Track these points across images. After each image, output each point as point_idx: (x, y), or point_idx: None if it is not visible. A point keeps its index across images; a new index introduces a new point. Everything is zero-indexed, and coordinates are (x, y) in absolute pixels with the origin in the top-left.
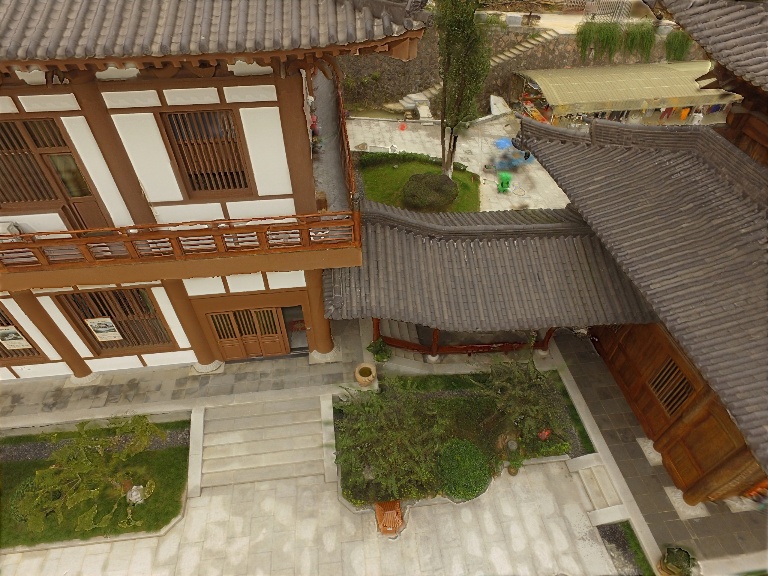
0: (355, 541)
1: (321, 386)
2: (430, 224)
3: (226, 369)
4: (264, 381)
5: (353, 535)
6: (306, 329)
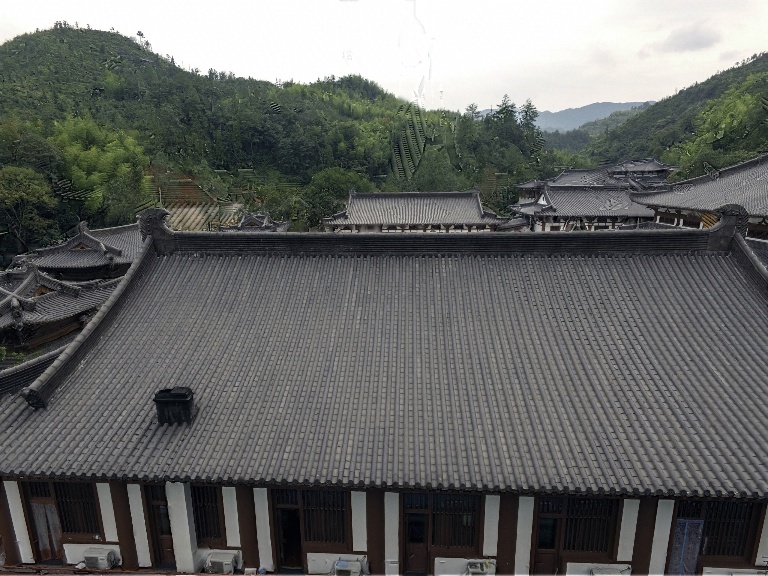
0: None
1: None
2: None
3: None
4: None
5: None
6: None
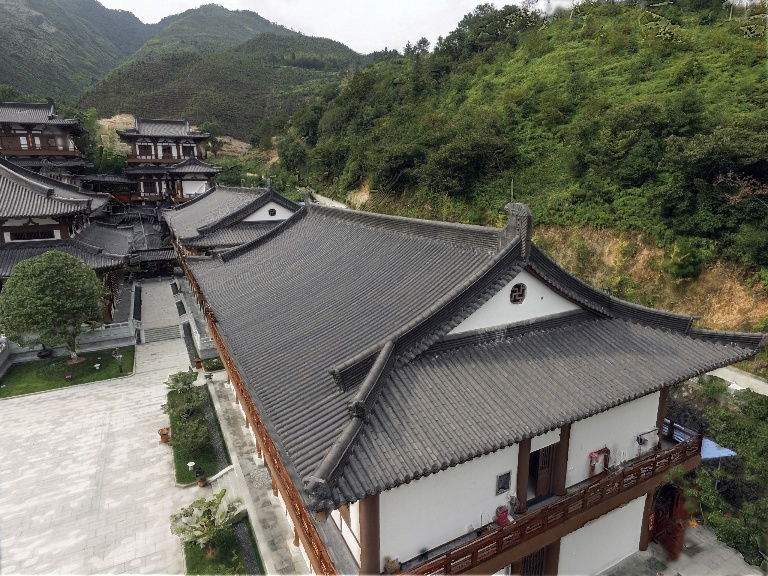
0: None
1: None
2: None
3: None
4: None
5: None
6: None
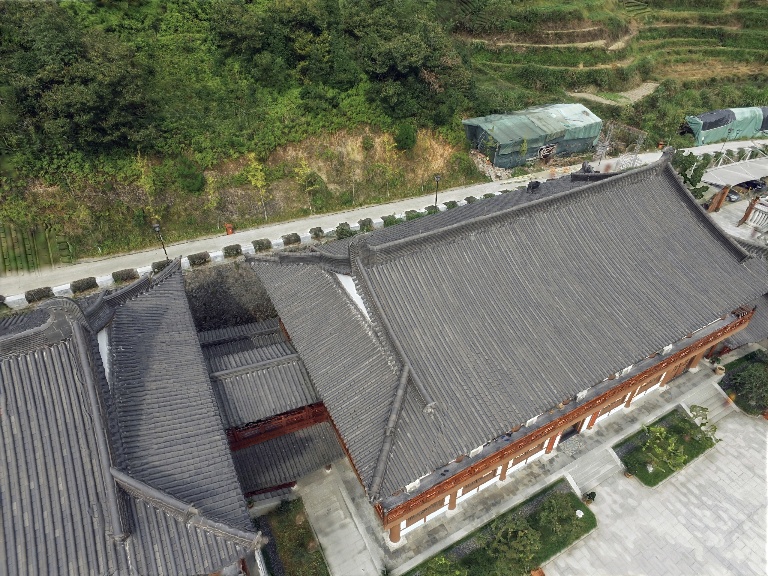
0: (766, 426)
1: (708, 380)
2: None
3: (670, 386)
4: (688, 385)
5: (764, 425)
6: (694, 359)
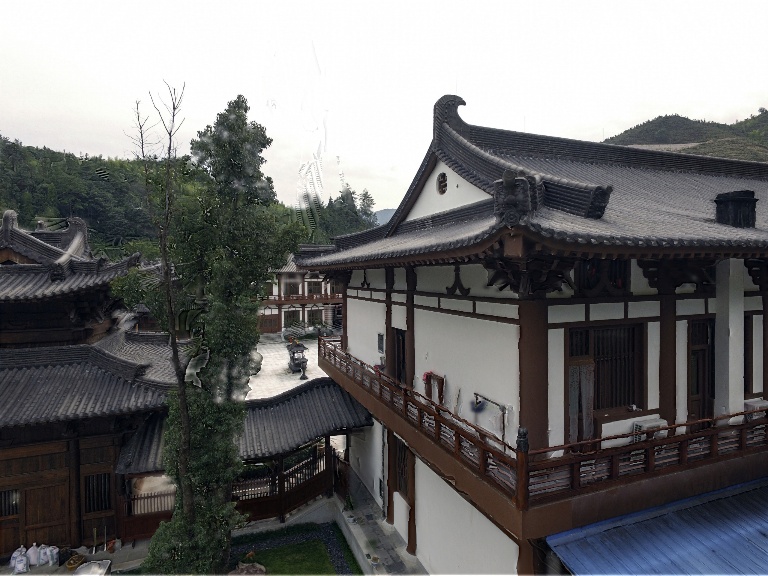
0: None
1: None
2: (281, 394)
3: None
4: None
5: None
6: None
